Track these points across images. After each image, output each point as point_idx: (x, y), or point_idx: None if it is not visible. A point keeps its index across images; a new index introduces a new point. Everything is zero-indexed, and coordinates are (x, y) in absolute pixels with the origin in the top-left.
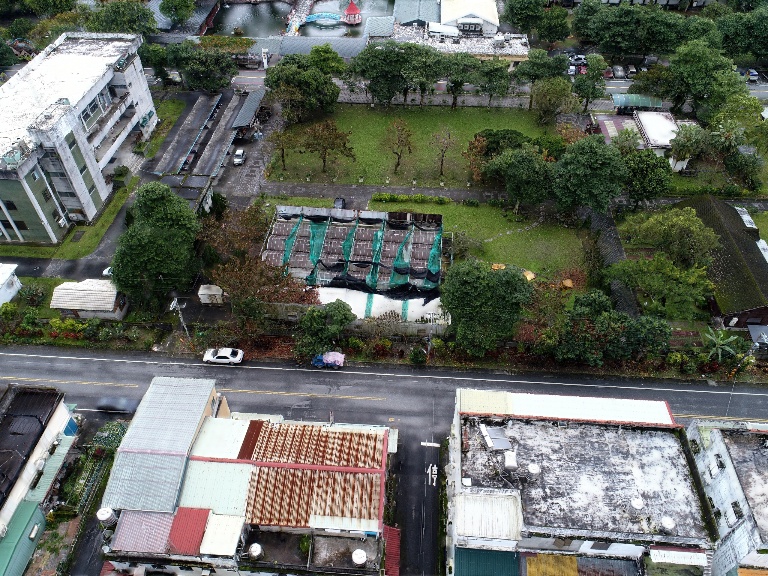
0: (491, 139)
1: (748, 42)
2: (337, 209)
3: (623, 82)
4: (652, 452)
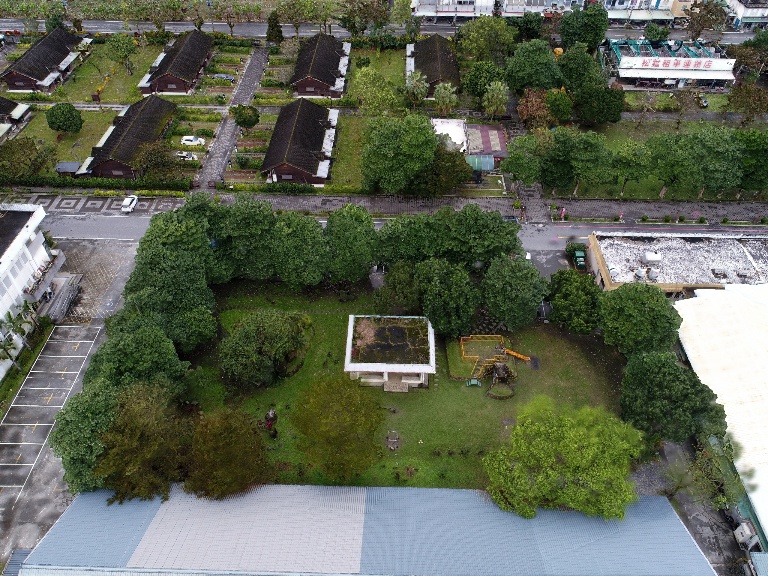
0: (610, 89)
1: None
2: (693, 58)
3: None
4: None
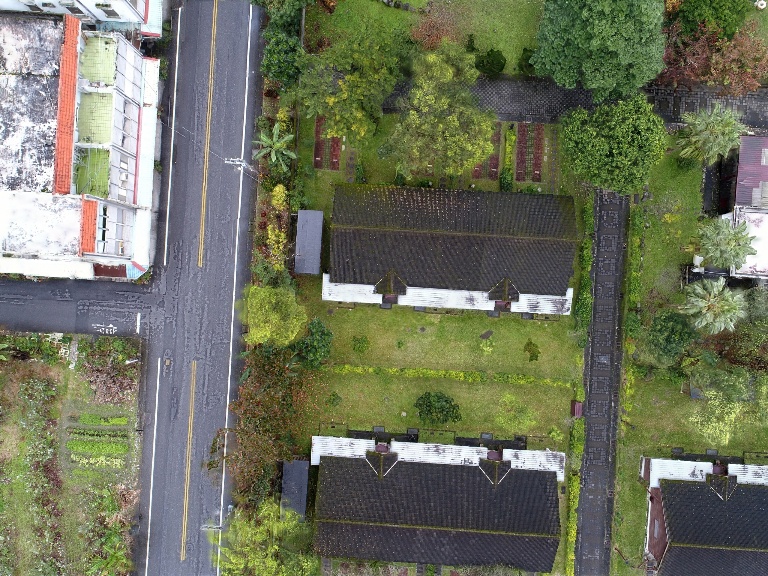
0: None
1: None
2: None
3: None
4: None
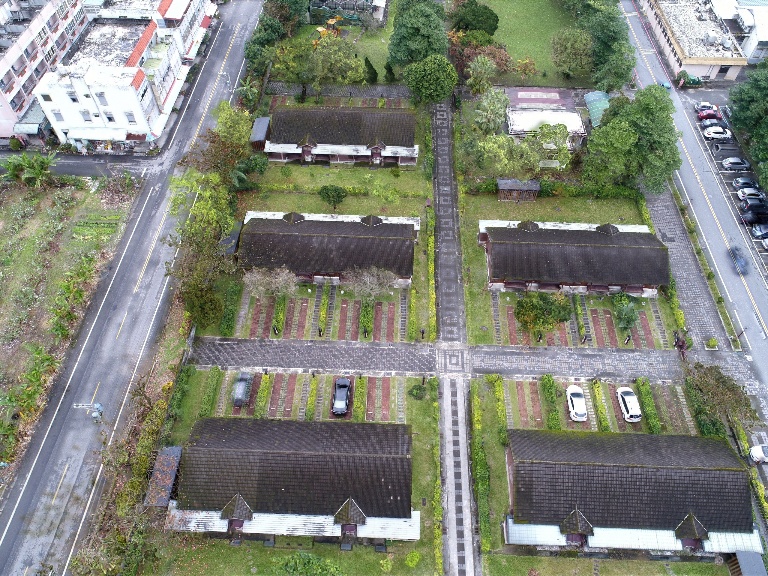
0: (466, 4)
1: None
2: None
3: (699, 146)
4: (151, 7)
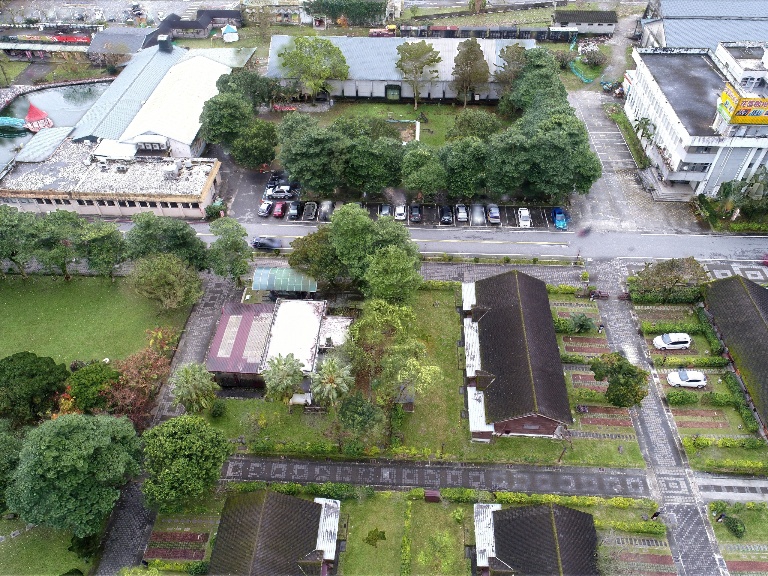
0: None
1: (479, 177)
2: None
3: None
4: None
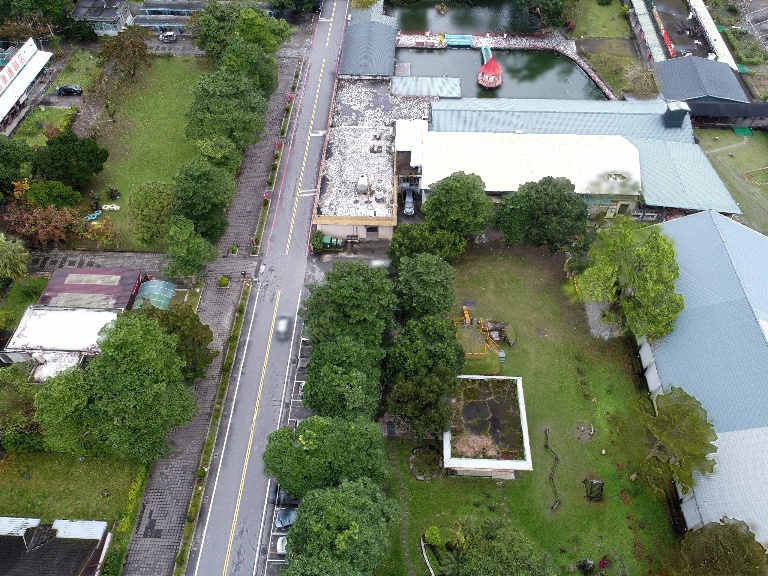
0: (55, 140)
1: None
2: (8, 64)
3: (287, 355)
4: None
